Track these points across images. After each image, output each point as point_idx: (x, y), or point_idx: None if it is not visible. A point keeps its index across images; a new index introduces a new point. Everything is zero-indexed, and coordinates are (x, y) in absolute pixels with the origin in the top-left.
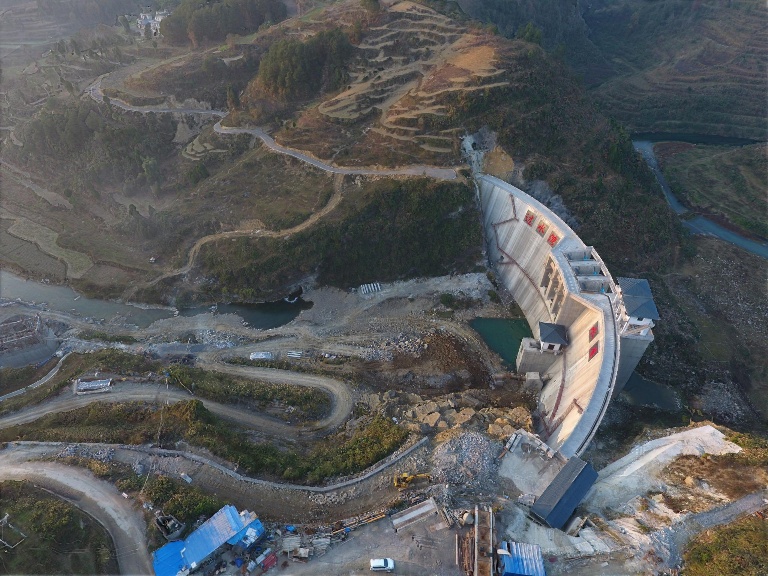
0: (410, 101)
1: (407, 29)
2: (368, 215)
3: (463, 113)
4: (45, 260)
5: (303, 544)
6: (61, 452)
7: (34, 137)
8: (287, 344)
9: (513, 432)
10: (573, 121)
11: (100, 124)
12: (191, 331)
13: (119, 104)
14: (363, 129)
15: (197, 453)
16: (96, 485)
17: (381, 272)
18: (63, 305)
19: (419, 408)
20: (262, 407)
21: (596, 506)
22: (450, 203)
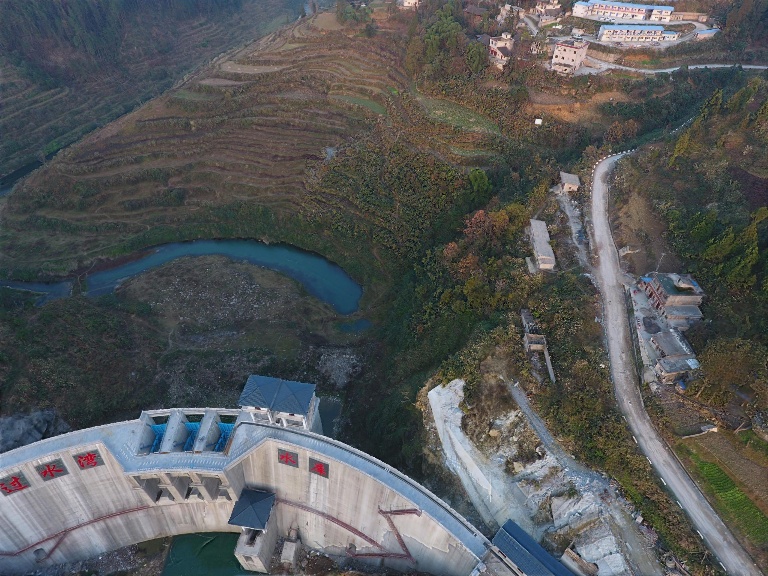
0: None
1: None
2: None
3: None
4: None
5: None
6: None
7: None
8: None
9: None
10: None
11: None
12: None
13: None
14: None
15: None
16: None
17: None
18: None
19: None
20: None
21: (532, 531)
22: None
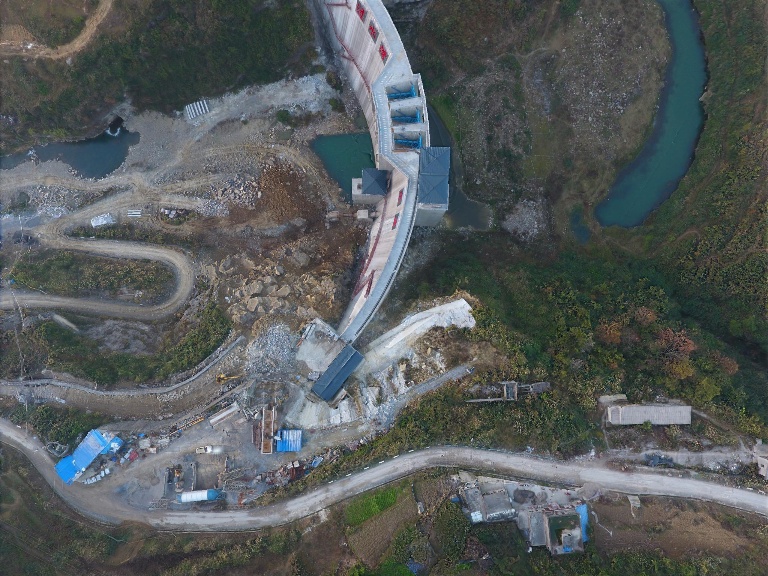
0: None
1: None
2: (159, 16)
3: None
4: None
5: (152, 443)
6: None
7: None
8: (124, 201)
9: (310, 322)
10: None
11: None
12: (20, 190)
13: None
14: None
15: (62, 378)
16: None
17: (203, 88)
18: None
19: (245, 289)
20: (113, 295)
21: (362, 373)
22: None
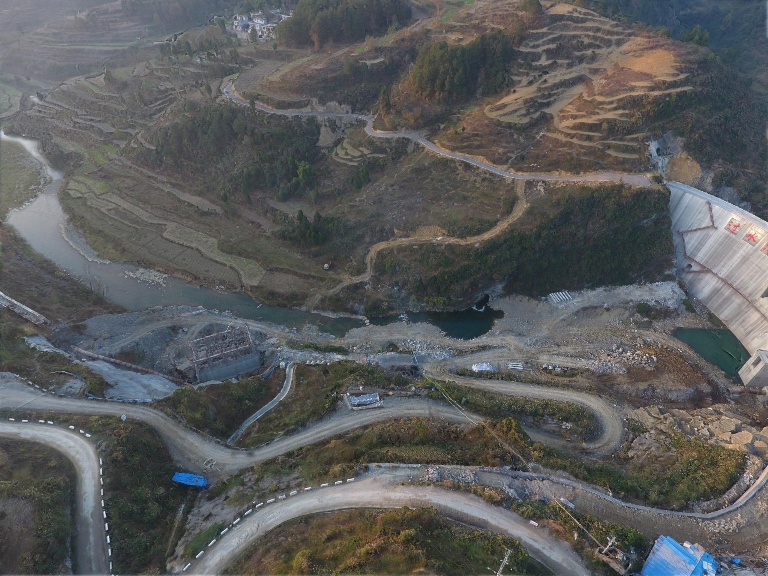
0: (587, 105)
1: (569, 32)
2: (558, 222)
3: (648, 118)
4: (214, 266)
5: None
6: (427, 475)
7: (171, 140)
8: (502, 355)
9: None
10: (749, 126)
11: (249, 128)
12: (391, 341)
13: (260, 107)
14: (536, 134)
15: (557, 476)
16: (494, 512)
17: (571, 280)
18: (247, 313)
19: (714, 426)
20: (537, 423)
21: None
22: (646, 210)
